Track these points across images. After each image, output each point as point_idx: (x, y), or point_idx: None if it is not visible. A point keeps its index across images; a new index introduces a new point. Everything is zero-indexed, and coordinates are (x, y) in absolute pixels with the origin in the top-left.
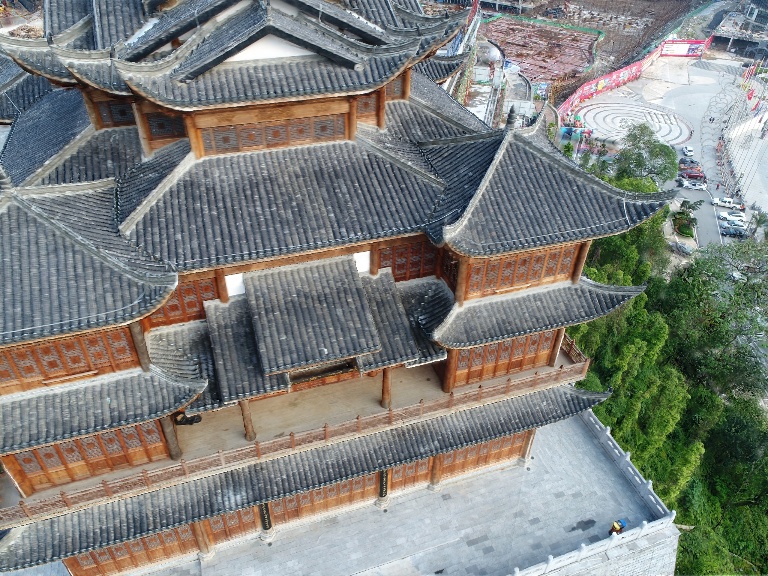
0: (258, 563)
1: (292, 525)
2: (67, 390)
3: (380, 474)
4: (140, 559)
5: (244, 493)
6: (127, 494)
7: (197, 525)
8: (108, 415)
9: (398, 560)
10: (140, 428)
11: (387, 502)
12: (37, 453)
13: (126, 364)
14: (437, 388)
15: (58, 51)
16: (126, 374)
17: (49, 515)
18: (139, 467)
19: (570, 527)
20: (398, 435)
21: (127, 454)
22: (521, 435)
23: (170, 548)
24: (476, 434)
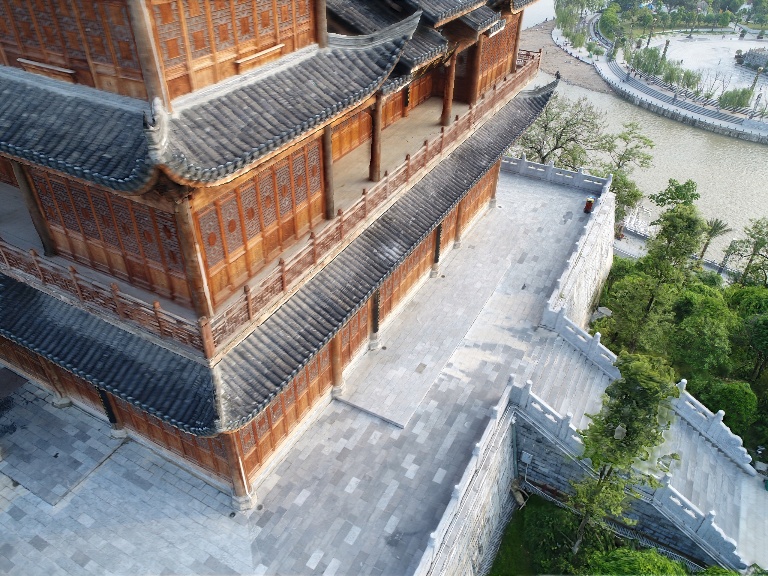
0: (392, 364)
1: (386, 324)
2: (259, 80)
3: (437, 229)
4: (289, 421)
5: (396, 244)
6: (327, 257)
7: (338, 336)
8: (328, 96)
9: (490, 298)
10: (307, 164)
11: (440, 268)
12: (221, 222)
13: (303, 37)
14: (463, 105)
15: None
16: (306, 53)
17: (267, 311)
18: (304, 238)
19: (562, 221)
20: (459, 158)
21: (295, 216)
22: (493, 170)
23: (312, 391)
24: (502, 142)
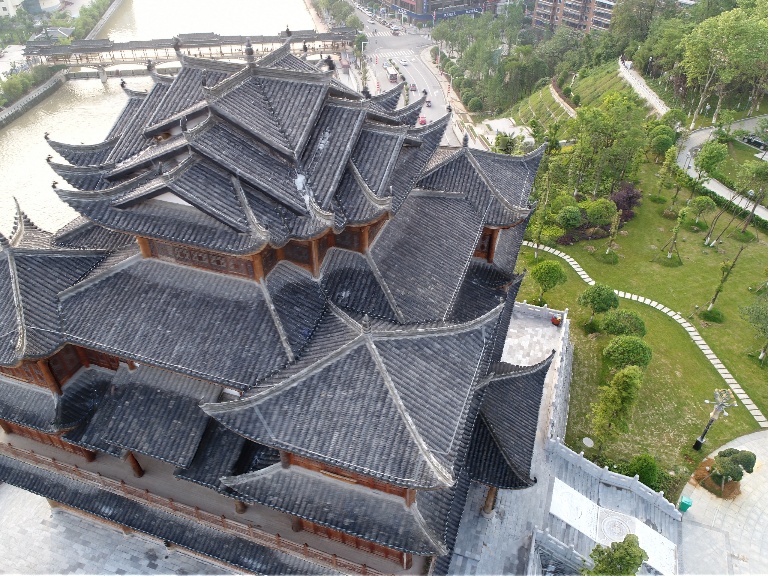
0: None
1: None
2: None
3: None
4: None
5: None
6: None
7: None
8: None
9: None
10: None
11: None
12: None
13: None
14: None
15: (423, 99)
16: None
17: None
18: None
19: None
20: None
21: None
22: None
23: None
24: None
